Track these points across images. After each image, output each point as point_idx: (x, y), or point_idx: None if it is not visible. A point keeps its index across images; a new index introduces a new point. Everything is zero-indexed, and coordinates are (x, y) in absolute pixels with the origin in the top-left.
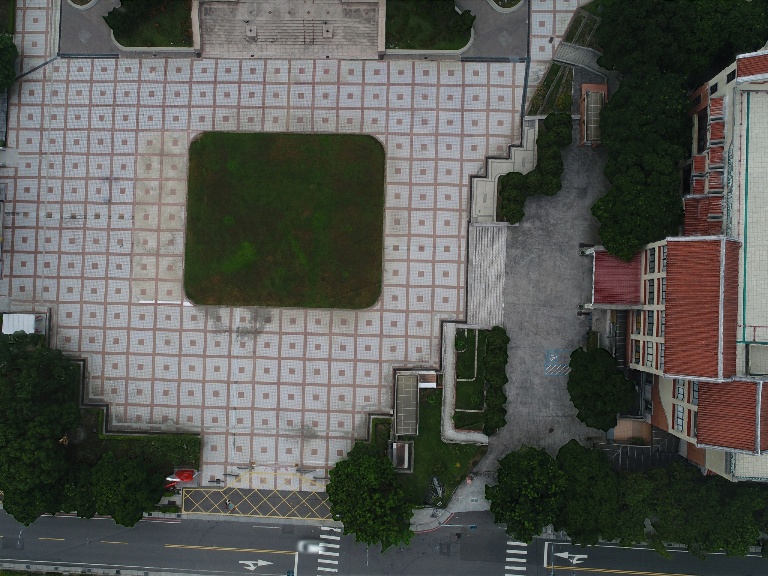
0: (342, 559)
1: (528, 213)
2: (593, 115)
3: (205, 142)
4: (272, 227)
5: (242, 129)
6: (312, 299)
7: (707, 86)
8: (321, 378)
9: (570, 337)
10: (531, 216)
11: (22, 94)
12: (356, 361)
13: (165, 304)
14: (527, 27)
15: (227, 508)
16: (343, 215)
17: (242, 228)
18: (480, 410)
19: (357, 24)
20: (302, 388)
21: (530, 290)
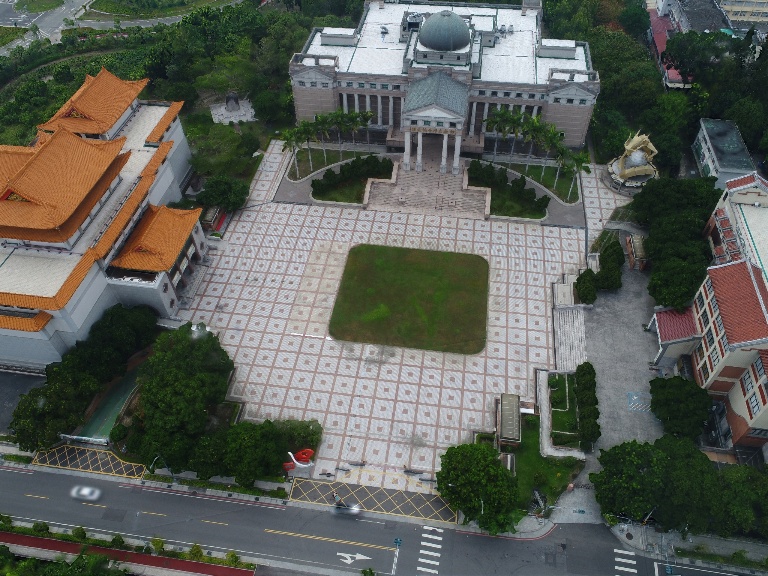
0: (443, 560)
1: (598, 303)
2: (638, 245)
3: (361, 249)
4: (403, 297)
5: (388, 245)
6: (429, 344)
7: (712, 215)
8: (433, 400)
9: (646, 384)
10: (601, 305)
11: (242, 216)
12: (463, 390)
13: (311, 337)
14: (583, 214)
15: (333, 500)
16: (457, 296)
17: (380, 296)
18: (575, 433)
19: (471, 201)
20: (415, 406)
21: (607, 349)
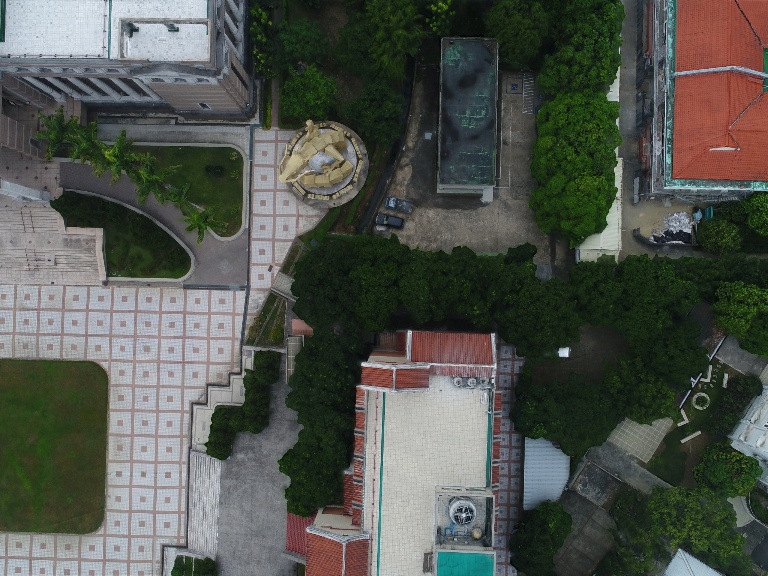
0: None
1: (242, 444)
2: (292, 359)
3: None
4: None
5: None
6: (37, 524)
7: None
8: None
9: (281, 566)
10: (245, 447)
11: None
12: None
13: None
14: (247, 255)
15: None
16: (67, 441)
17: None
18: None
19: (78, 253)
20: None
21: (243, 520)
